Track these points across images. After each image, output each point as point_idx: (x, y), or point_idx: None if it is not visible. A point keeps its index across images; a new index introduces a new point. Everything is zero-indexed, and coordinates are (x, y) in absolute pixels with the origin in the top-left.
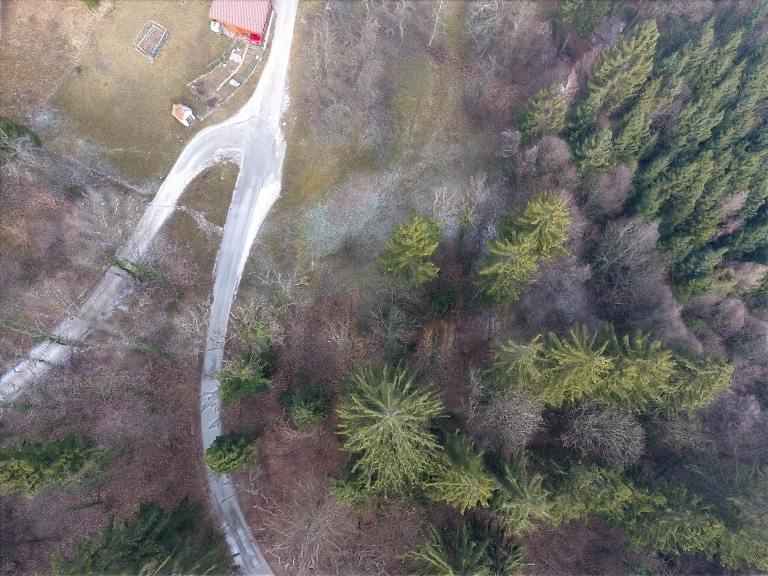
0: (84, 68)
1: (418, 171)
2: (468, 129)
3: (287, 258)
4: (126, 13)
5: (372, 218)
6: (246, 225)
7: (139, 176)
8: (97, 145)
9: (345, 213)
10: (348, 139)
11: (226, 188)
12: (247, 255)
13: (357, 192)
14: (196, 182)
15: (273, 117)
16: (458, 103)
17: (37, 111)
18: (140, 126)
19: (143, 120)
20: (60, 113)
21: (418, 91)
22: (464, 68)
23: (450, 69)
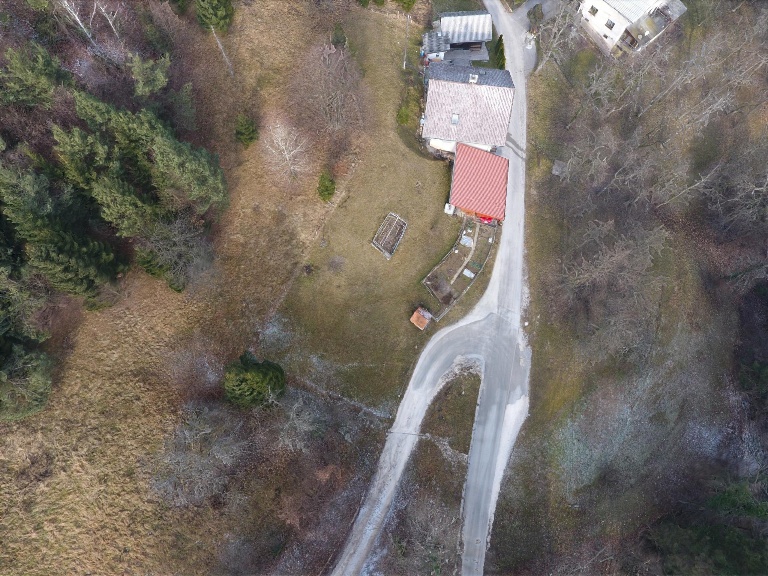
0: (314, 268)
1: (666, 371)
2: (707, 311)
3: (539, 491)
4: (361, 202)
5: (626, 436)
6: (494, 452)
7: (375, 395)
8: (331, 361)
9: (597, 431)
10: (608, 351)
11: (468, 405)
12: (498, 491)
13: (607, 403)
14: (438, 401)
15: (513, 315)
16: (698, 282)
17: (266, 323)
18: (375, 334)
19: (378, 327)
20: (290, 323)
21: (661, 273)
22: (692, 232)
23: (681, 236)
